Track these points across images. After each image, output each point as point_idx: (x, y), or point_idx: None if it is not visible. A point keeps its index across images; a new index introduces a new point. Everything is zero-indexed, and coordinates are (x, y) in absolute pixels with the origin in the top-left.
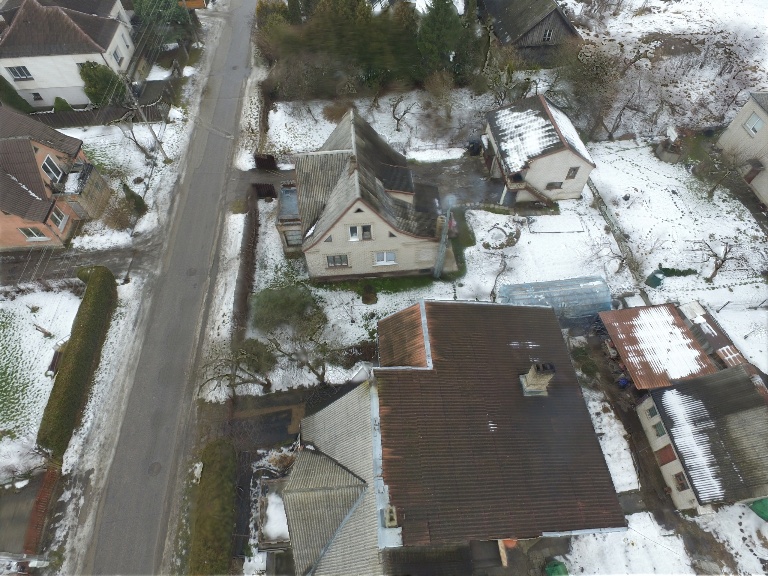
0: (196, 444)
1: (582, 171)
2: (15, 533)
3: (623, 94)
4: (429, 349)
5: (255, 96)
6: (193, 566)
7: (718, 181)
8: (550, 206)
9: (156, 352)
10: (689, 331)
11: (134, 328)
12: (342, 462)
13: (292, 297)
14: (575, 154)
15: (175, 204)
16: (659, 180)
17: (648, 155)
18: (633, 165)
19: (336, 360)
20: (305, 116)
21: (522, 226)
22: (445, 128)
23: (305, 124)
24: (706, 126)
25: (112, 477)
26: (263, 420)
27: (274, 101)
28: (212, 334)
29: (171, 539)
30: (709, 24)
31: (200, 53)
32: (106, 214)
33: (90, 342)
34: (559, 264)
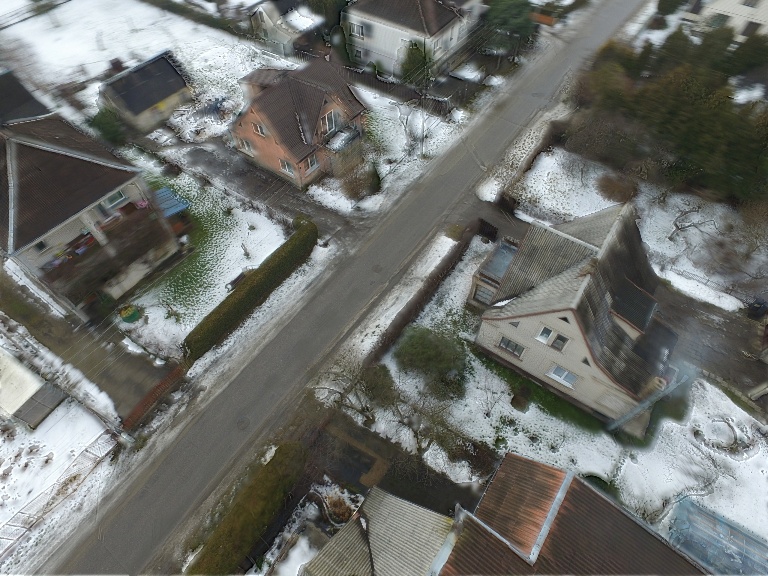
0: (284, 427)
1: None
2: (134, 396)
3: None
4: (544, 538)
5: (536, 131)
6: (211, 541)
7: None
8: None
9: (307, 322)
10: None
11: (305, 290)
12: None
13: (444, 355)
14: None
15: (403, 199)
16: None
17: None
18: None
19: (447, 443)
20: (574, 173)
21: (766, 444)
22: (733, 267)
23: (569, 182)
24: None
25: (213, 405)
26: (347, 450)
27: (552, 144)
28: (358, 337)
29: (216, 495)
30: None
31: (511, 68)
32: (346, 178)
33: (267, 282)
34: None
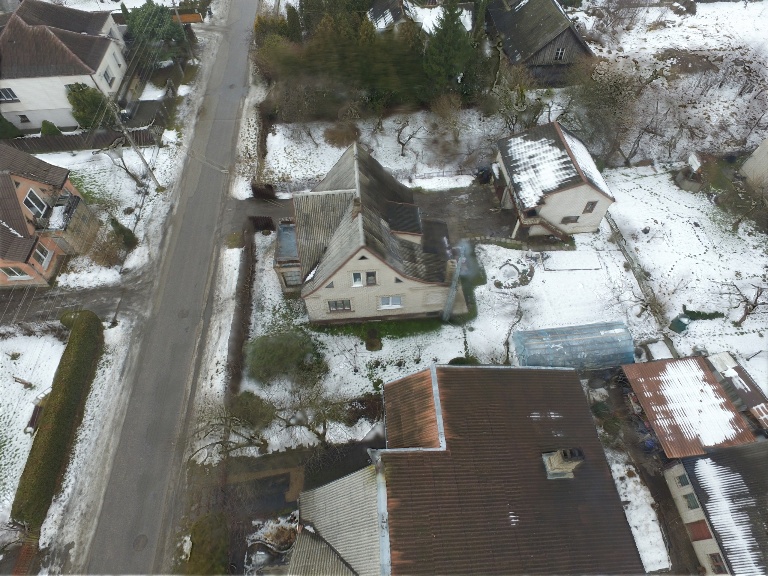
0: (186, 513)
1: (600, 205)
2: None
3: (639, 115)
4: (442, 425)
5: (253, 117)
6: None
7: (743, 212)
8: (565, 240)
9: (144, 406)
10: (721, 389)
11: (121, 378)
12: (345, 557)
13: (291, 347)
14: (594, 189)
15: (167, 237)
16: (680, 211)
17: (667, 183)
18: (652, 194)
19: (338, 415)
20: (305, 139)
21: (536, 262)
22: (453, 154)
23: (305, 148)
24: (728, 151)
25: (94, 552)
26: (259, 485)
27: (273, 123)
28: (205, 385)
29: None
30: (727, 39)
31: (196, 70)
32: (94, 248)
33: (73, 396)
34: (576, 306)
